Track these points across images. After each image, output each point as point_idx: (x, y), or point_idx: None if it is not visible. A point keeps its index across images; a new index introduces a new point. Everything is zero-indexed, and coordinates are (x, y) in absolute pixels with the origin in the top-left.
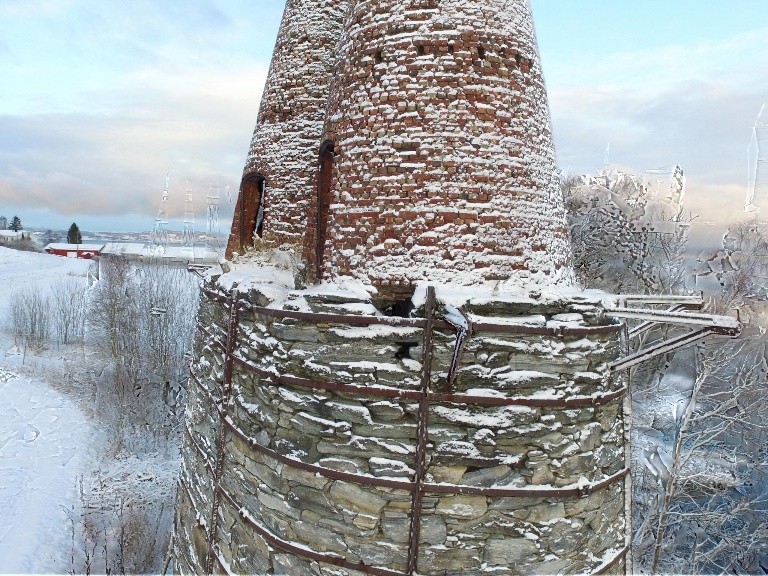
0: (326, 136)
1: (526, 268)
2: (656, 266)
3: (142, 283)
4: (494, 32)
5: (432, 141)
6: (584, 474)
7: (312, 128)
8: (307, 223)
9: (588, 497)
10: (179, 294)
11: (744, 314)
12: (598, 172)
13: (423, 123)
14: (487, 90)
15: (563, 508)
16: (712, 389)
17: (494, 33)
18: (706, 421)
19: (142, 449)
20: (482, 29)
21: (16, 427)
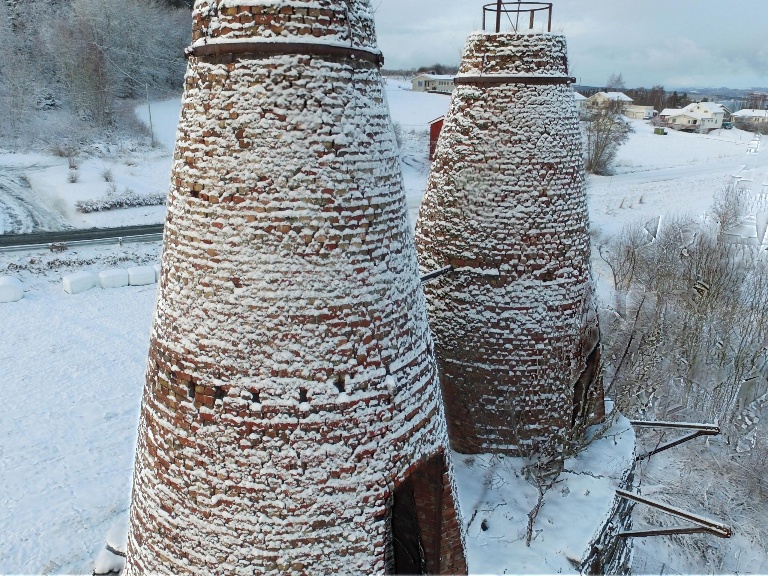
0: None
1: None
2: None
3: (691, 251)
4: (170, 346)
5: None
6: None
7: None
8: None
9: None
10: (731, 272)
11: None
12: None
13: None
14: None
15: None
16: None
17: (169, 348)
18: None
19: None
20: (161, 339)
21: None
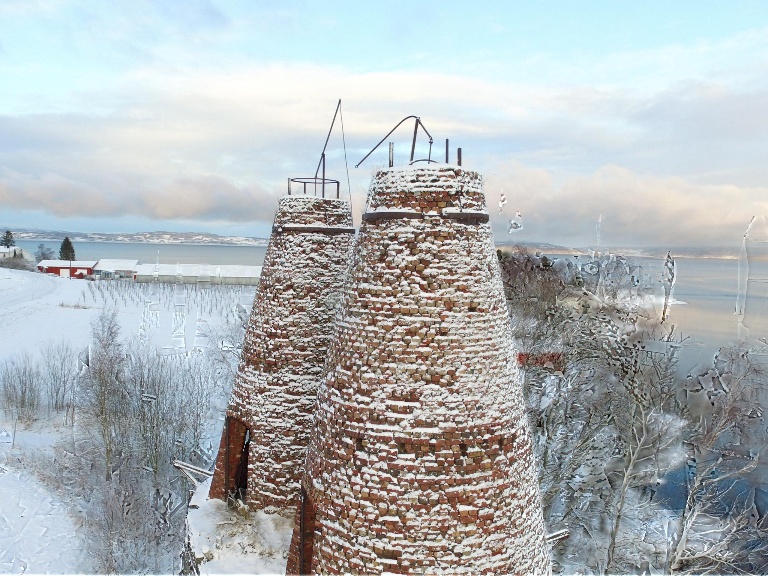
0: (308, 492)
1: None
2: (647, 384)
3: (132, 370)
4: (476, 424)
5: (413, 551)
6: None
7: (297, 383)
8: (290, 549)
9: None
10: (170, 379)
11: (735, 436)
12: (590, 254)
13: (404, 530)
14: (469, 490)
15: None
16: (703, 527)
17: (476, 425)
18: (697, 558)
19: (132, 563)
20: (464, 424)
21: (4, 545)
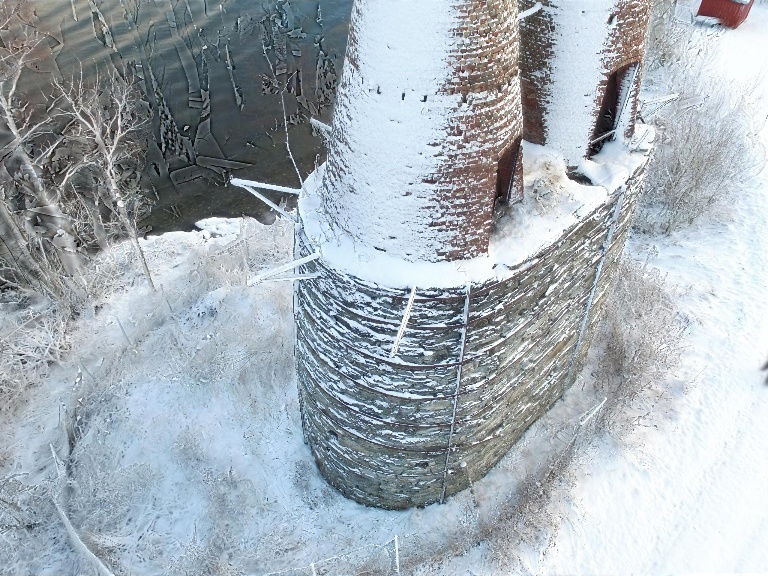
0: None
1: None
2: None
3: None
4: None
5: None
6: None
7: None
8: None
9: None
10: None
11: None
12: None
13: None
14: None
15: None
16: (97, 120)
17: None
18: None
19: None
20: None
21: None
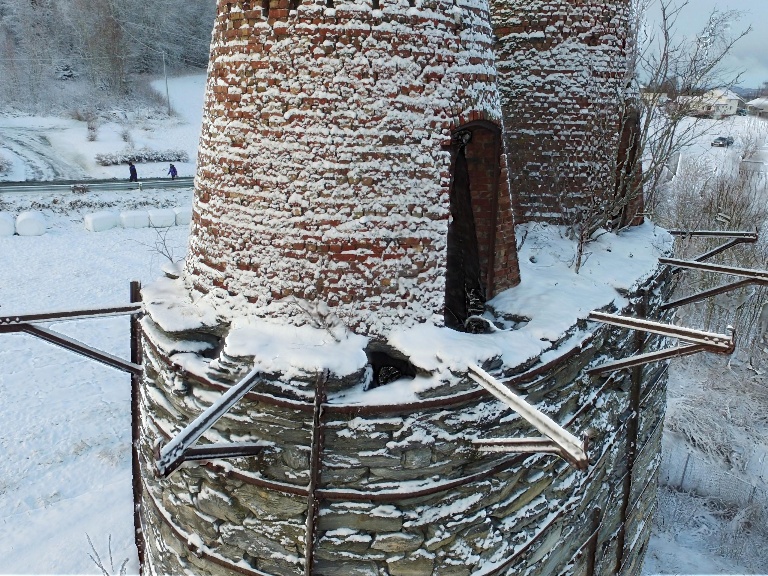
0: None
1: (226, 287)
2: None
3: (712, 184)
4: None
5: None
6: (200, 534)
7: None
8: None
9: (205, 560)
10: (753, 201)
11: None
12: None
13: None
14: (226, 61)
15: (181, 546)
16: None
17: None
18: None
19: None
20: None
21: None
